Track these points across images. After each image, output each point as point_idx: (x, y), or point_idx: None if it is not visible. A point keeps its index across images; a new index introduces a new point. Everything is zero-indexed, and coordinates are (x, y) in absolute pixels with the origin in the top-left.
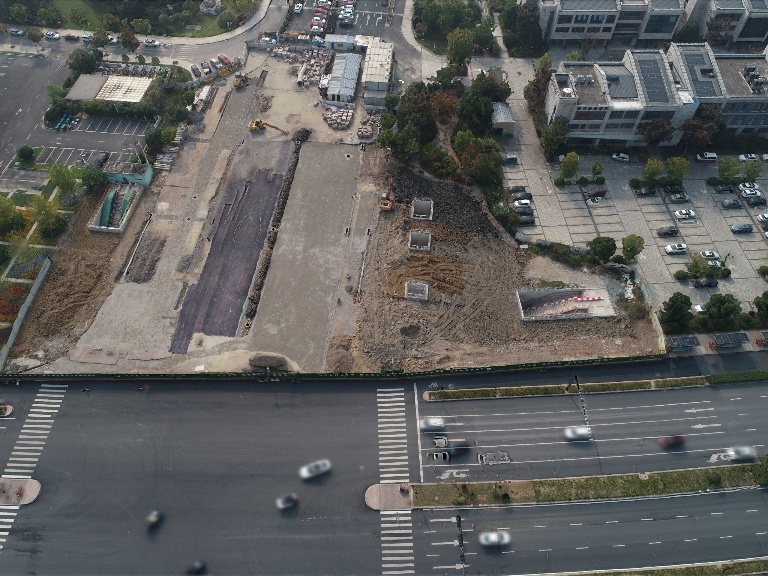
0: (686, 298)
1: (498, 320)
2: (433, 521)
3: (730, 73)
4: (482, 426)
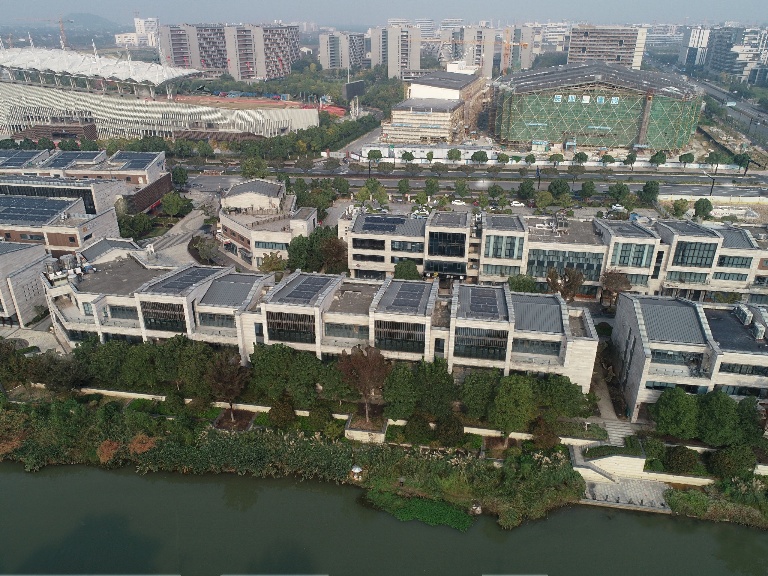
0: (651, 182)
1: (765, 213)
2: (766, 183)
3: (580, 235)
4: (755, 194)
